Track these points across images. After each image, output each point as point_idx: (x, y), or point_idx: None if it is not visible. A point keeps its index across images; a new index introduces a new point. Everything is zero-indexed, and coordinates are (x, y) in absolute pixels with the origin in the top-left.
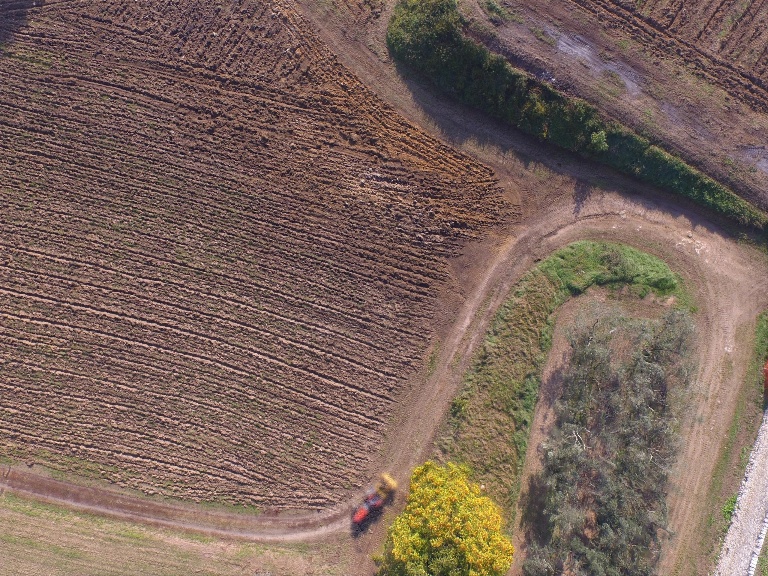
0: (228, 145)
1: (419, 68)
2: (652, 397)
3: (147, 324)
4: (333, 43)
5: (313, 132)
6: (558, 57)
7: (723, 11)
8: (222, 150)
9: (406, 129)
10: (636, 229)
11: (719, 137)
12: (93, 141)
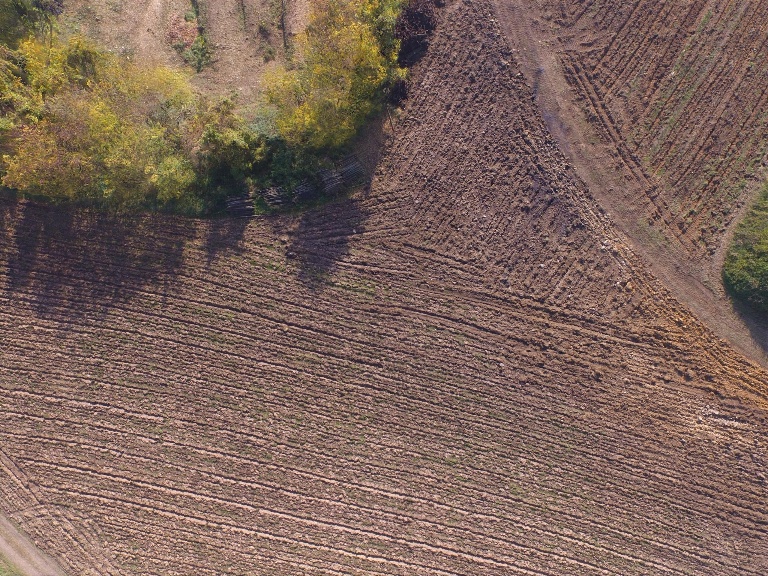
0: (559, 378)
1: (762, 310)
2: None
3: (484, 561)
4: (666, 278)
5: (647, 367)
6: None
7: None
8: (553, 383)
9: (745, 367)
10: None
11: None
12: (422, 373)
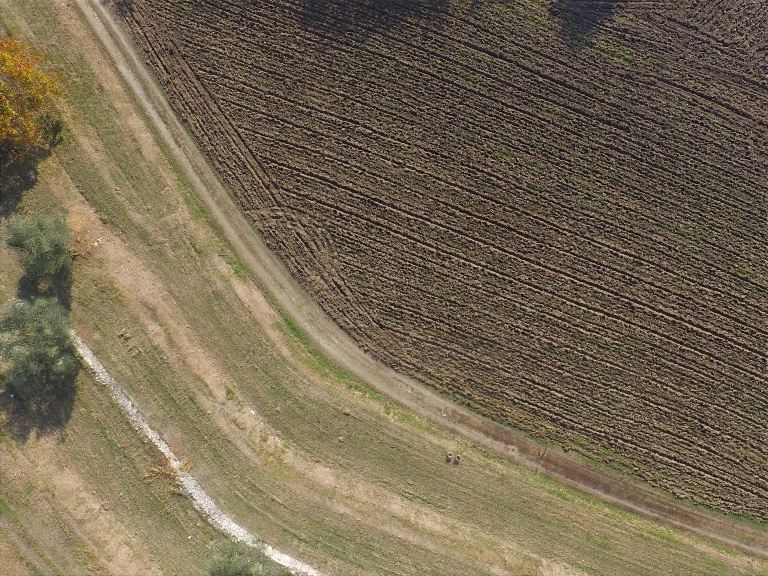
0: None
1: None
2: None
3: (703, 332)
4: None
5: None
6: None
7: None
8: None
9: None
10: None
11: None
12: (668, 144)
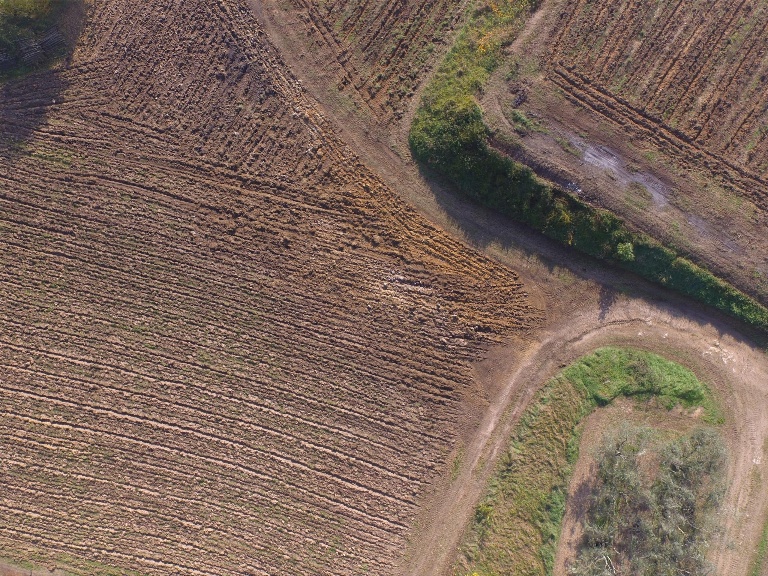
0: (249, 246)
1: (442, 172)
2: (683, 522)
3: (169, 428)
4: (355, 144)
5: (335, 233)
6: (584, 168)
7: (750, 123)
8: (243, 251)
9: (429, 232)
10: (662, 336)
11: (747, 250)
12: (114, 241)
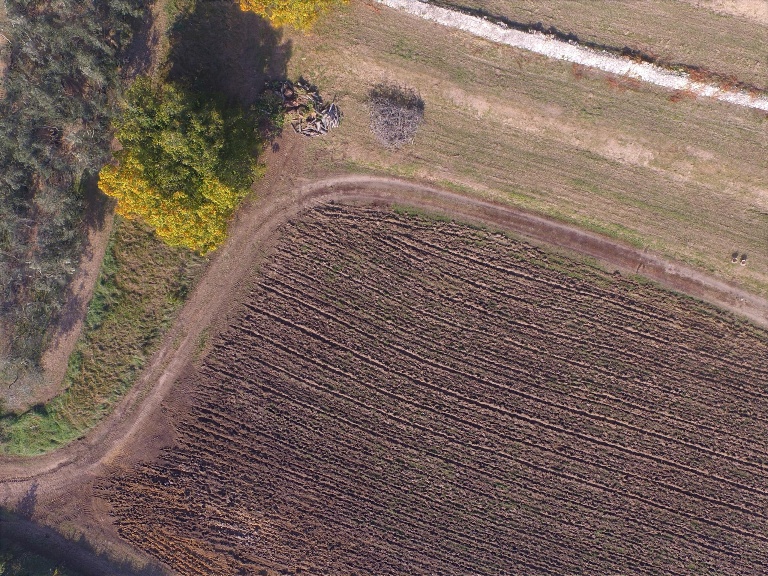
0: None
1: None
2: None
3: (489, 404)
4: None
5: None
6: None
7: None
8: (400, 574)
9: None
10: None
11: None
12: None
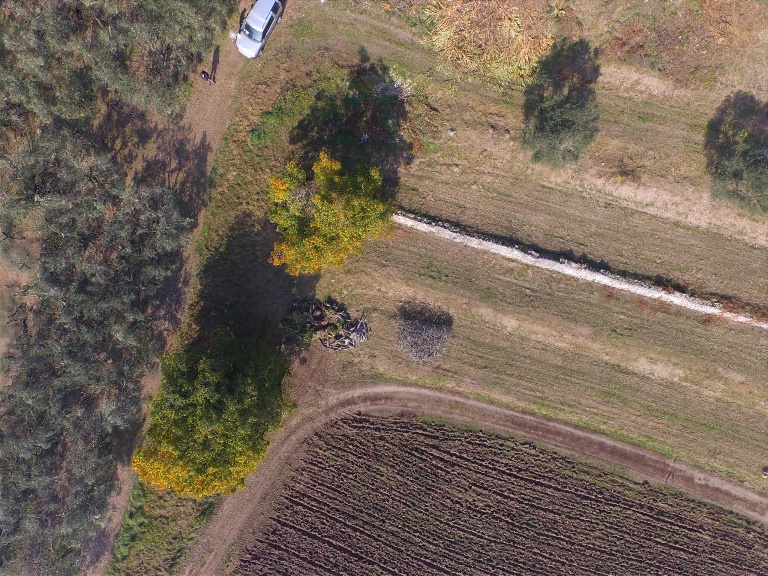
0: None
1: None
2: None
3: None
4: None
5: None
6: None
7: None
8: None
9: None
10: None
11: None
12: None
